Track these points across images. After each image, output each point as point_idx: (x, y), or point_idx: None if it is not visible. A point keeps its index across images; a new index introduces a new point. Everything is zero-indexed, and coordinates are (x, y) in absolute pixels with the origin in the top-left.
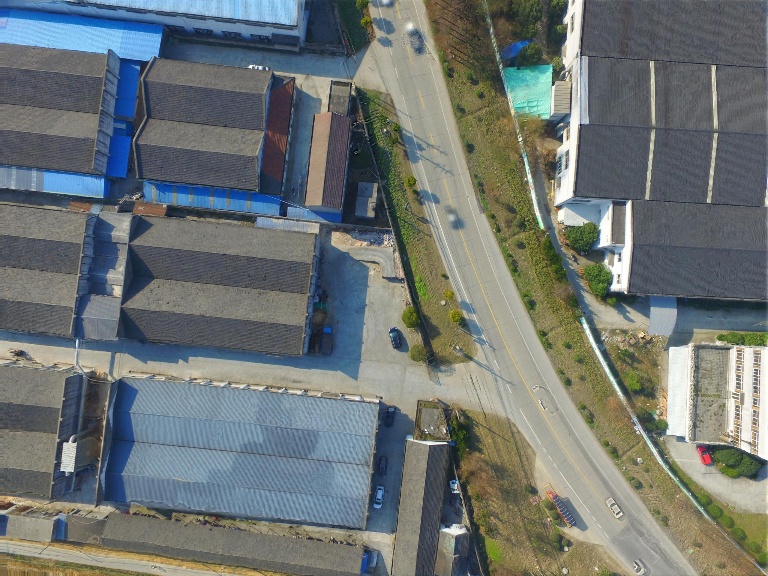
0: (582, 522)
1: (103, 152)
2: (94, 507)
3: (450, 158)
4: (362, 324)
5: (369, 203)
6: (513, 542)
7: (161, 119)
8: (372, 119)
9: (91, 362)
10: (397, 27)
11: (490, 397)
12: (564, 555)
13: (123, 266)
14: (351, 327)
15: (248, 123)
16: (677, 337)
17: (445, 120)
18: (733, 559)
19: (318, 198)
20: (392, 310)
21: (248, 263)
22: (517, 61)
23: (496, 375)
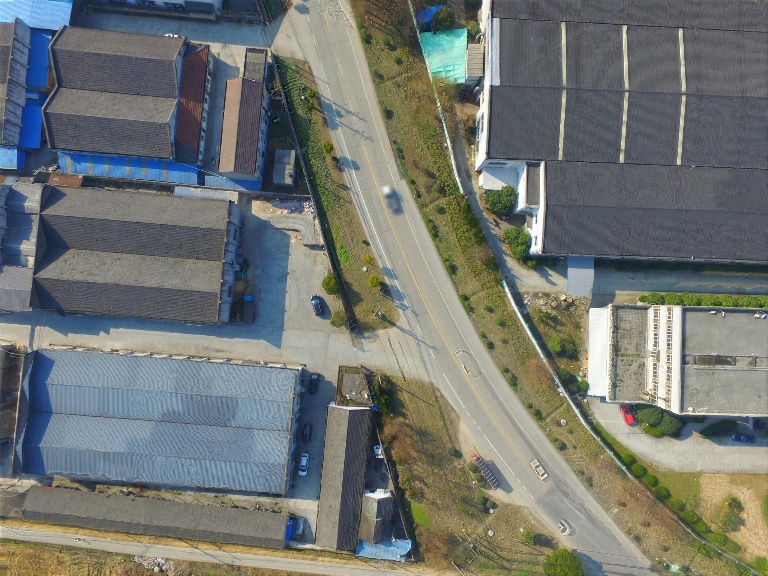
0: (507, 484)
1: (14, 122)
2: (17, 481)
3: (369, 124)
4: (284, 292)
5: (286, 170)
6: (439, 506)
7: (73, 88)
8: (290, 87)
9: (11, 336)
10: None
11: (413, 362)
12: (490, 517)
13: (35, 236)
14: (273, 295)
15: (161, 91)
16: (599, 299)
17: (364, 87)
18: (657, 517)
19: (230, 164)
20: (314, 278)
21: (162, 231)
22: (432, 25)
23: (419, 340)
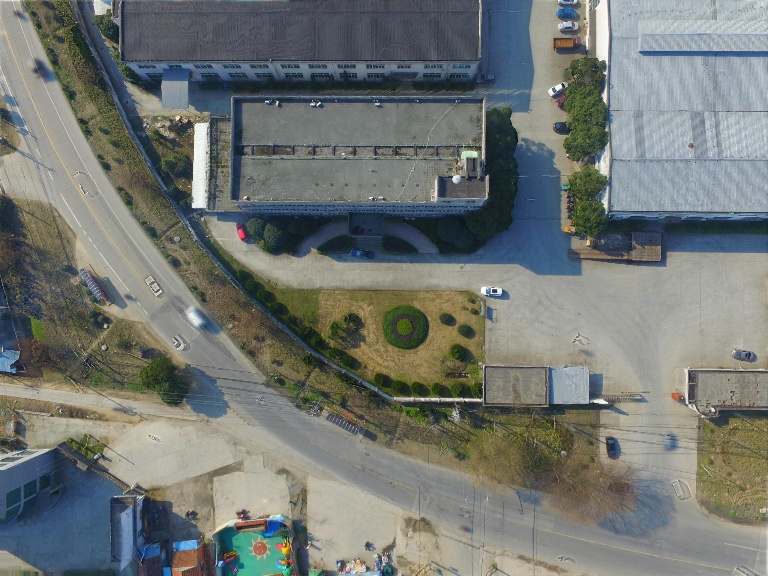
0: (122, 300)
1: None
2: None
3: None
4: None
5: None
6: (56, 322)
7: None
8: None
9: None
10: None
11: (33, 184)
12: (104, 332)
13: None
14: None
15: None
16: None
17: None
18: (272, 332)
19: None
20: None
21: None
22: None
23: (38, 163)
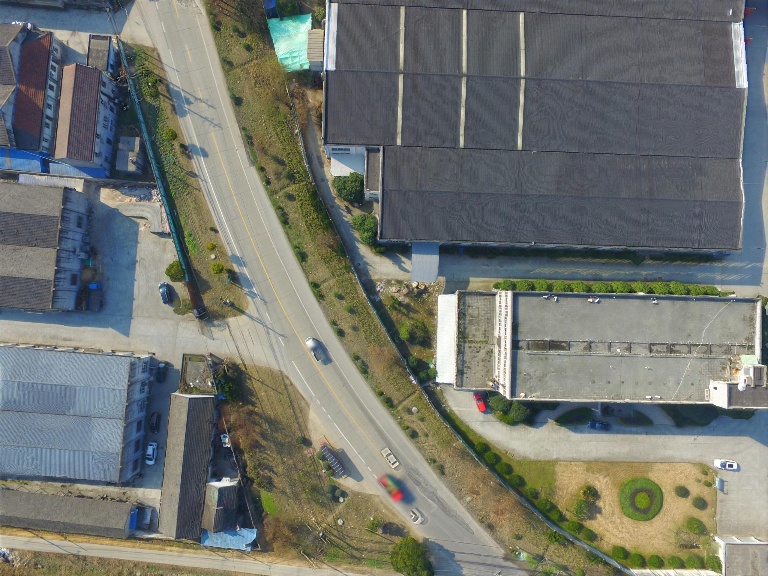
0: (357, 473)
1: None
2: None
3: (218, 111)
4: (133, 280)
5: (129, 157)
6: (288, 495)
7: None
8: (139, 74)
9: None
10: None
11: (262, 350)
12: (340, 506)
13: None
14: (122, 284)
15: None
16: (453, 286)
17: (213, 73)
18: (511, 506)
19: (64, 150)
20: (163, 266)
21: None
22: (277, 11)
23: (268, 328)
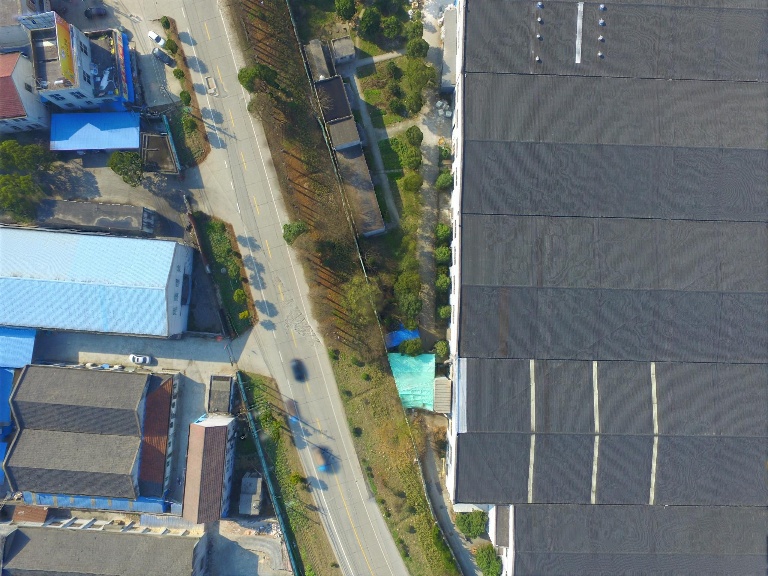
0: None
1: None
2: None
3: (337, 443)
4: None
5: (252, 501)
6: None
7: (35, 429)
8: (257, 405)
9: None
10: (280, 309)
11: None
12: None
13: None
14: None
15: (124, 431)
16: None
17: (331, 404)
18: None
19: (194, 515)
20: None
21: None
22: None
23: None
